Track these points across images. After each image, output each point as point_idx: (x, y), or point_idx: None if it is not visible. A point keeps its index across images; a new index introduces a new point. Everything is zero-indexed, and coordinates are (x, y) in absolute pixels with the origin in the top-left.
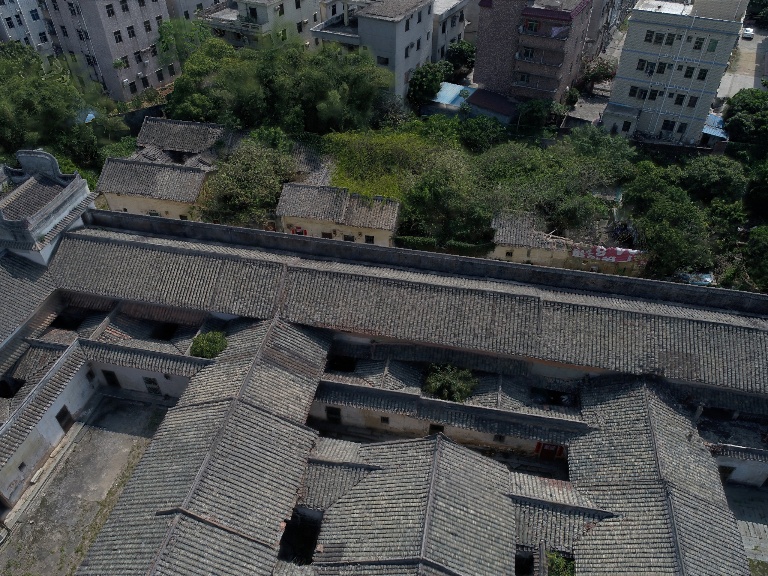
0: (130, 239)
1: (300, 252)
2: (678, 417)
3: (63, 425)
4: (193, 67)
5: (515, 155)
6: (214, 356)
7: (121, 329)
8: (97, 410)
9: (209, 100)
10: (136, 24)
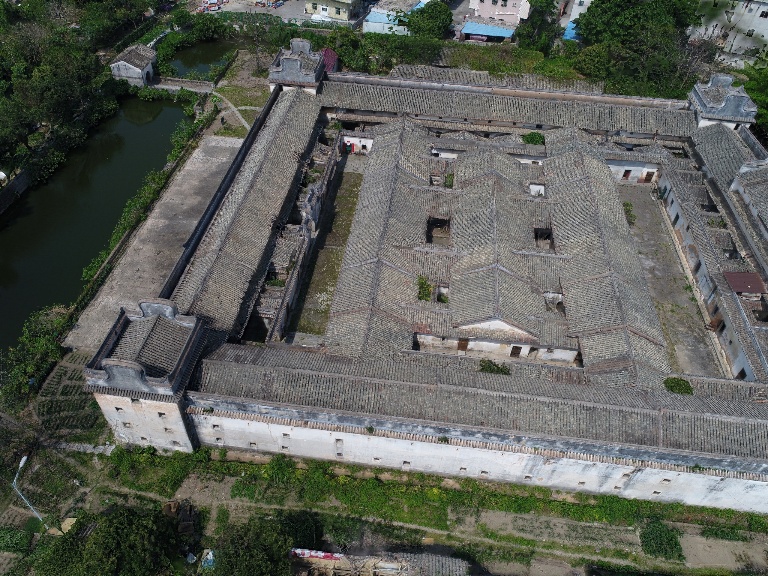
0: None
1: None
2: None
3: None
4: None
5: None
6: None
7: None
8: None
9: None
10: None
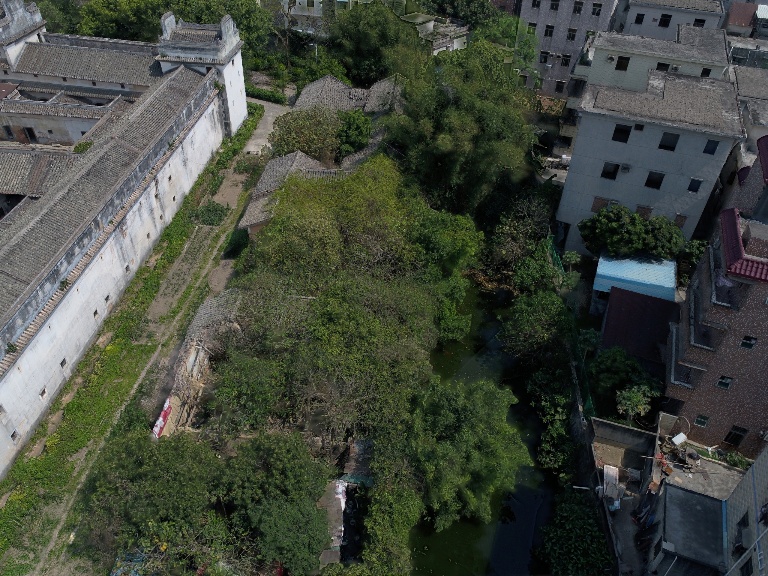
0: (181, 88)
1: None
2: None
3: None
4: (439, 52)
5: None
6: None
7: None
8: None
9: None
10: (559, 27)
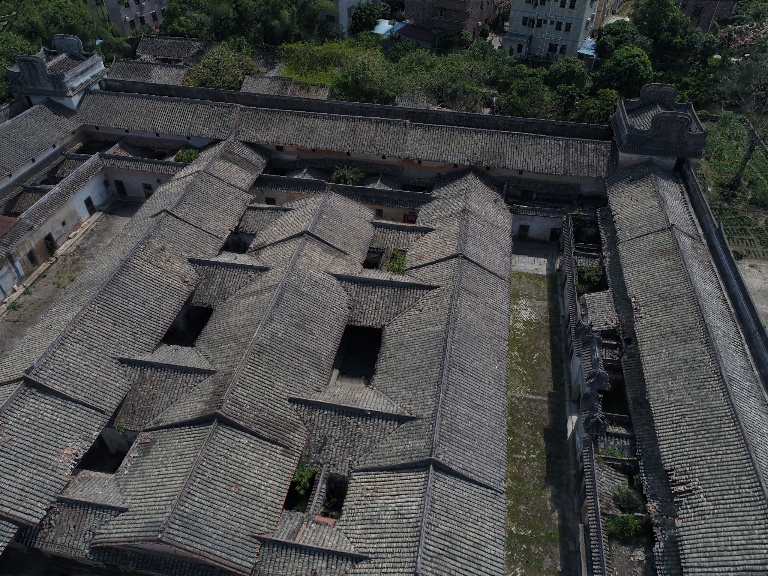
0: None
1: (251, 105)
2: (492, 192)
3: (89, 210)
4: None
5: (419, 57)
6: (190, 162)
7: (127, 152)
8: (111, 207)
9: (192, 22)
10: None
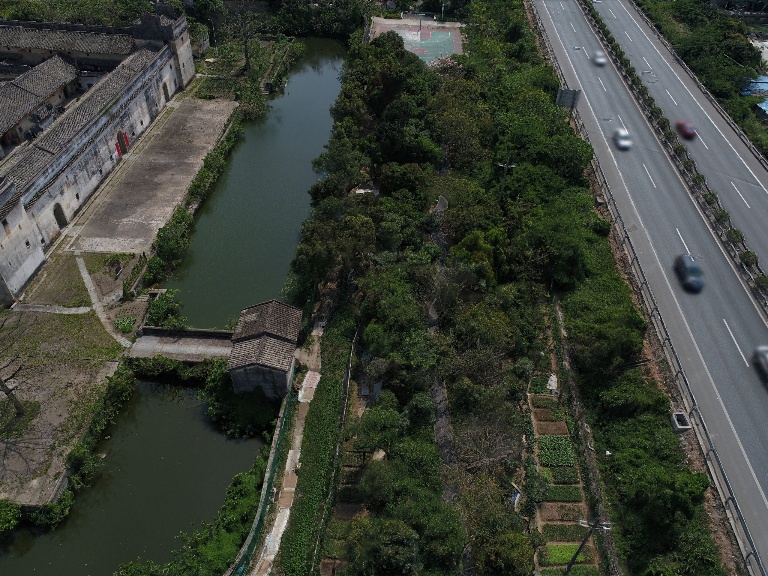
0: None
1: None
2: (68, 65)
3: None
4: None
5: (75, 0)
6: None
7: None
8: None
9: None
10: None
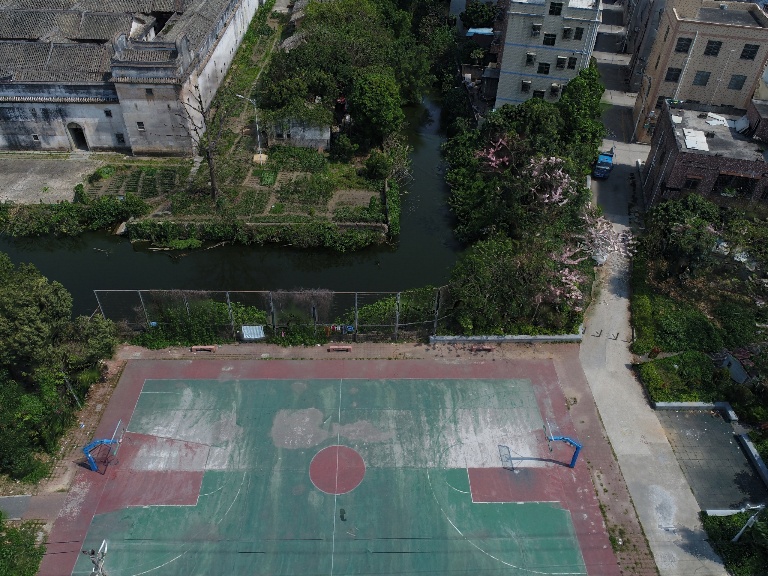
0: None
1: None
2: None
3: None
4: None
5: None
6: None
7: None
8: None
9: None
10: None
